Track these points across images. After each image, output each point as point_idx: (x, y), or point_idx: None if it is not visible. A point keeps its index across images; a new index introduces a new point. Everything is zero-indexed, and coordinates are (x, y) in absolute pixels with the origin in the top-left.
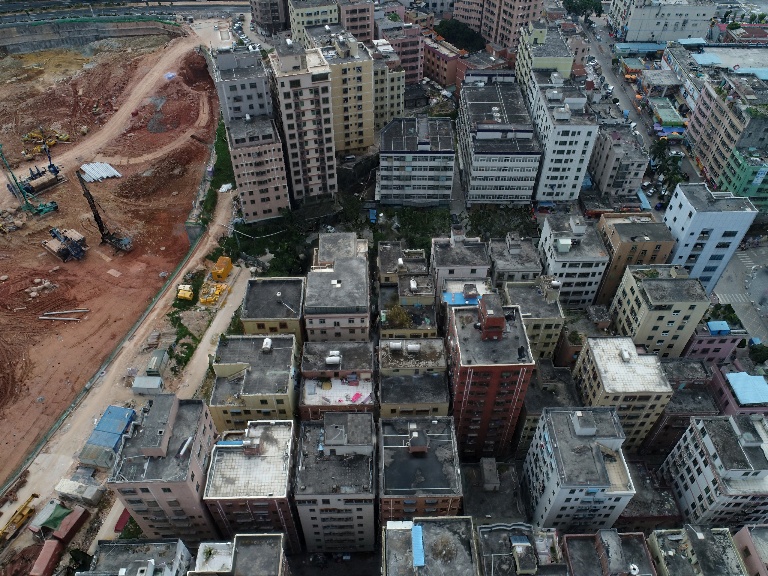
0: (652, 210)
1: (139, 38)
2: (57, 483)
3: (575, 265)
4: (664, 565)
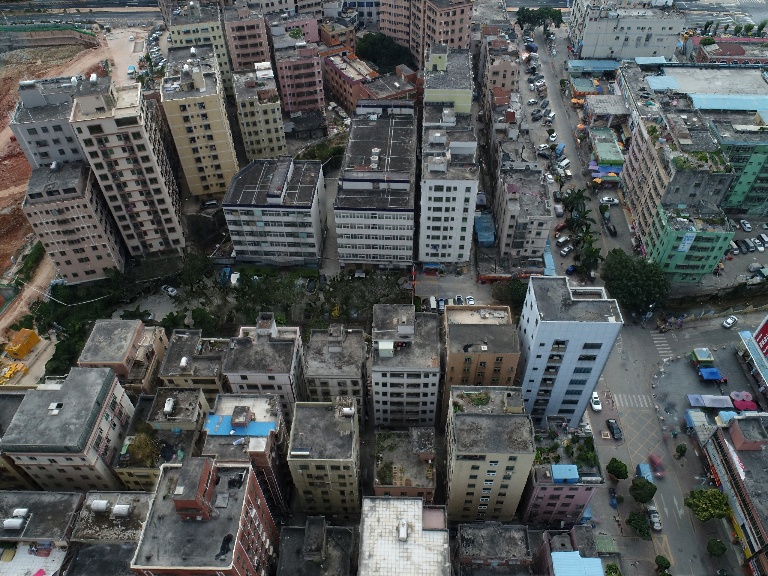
0: (562, 274)
1: (52, 49)
2: None
3: (399, 375)
4: None
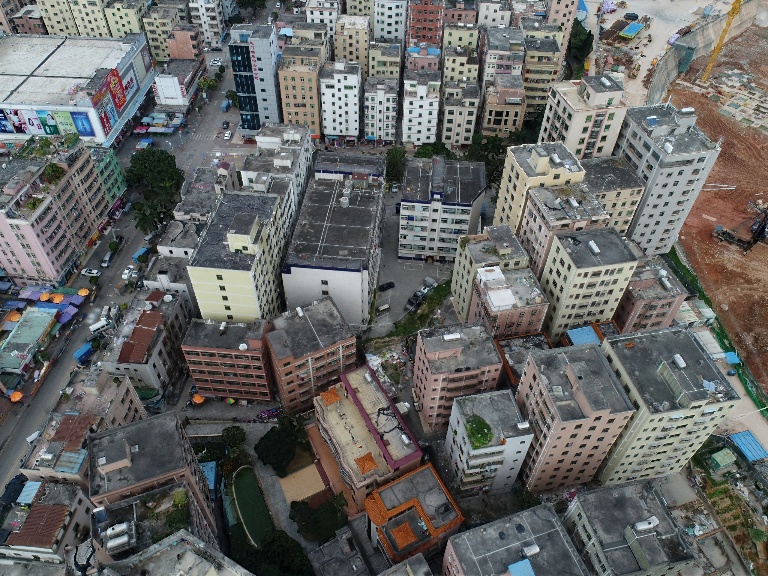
0: None
1: None
2: (628, 85)
3: None
4: None
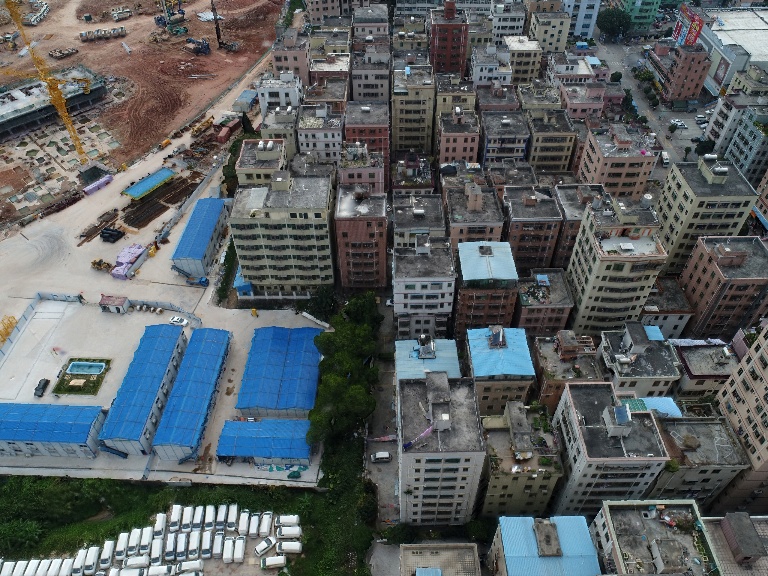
0: None
1: None
2: None
3: (506, 20)
4: (520, 92)
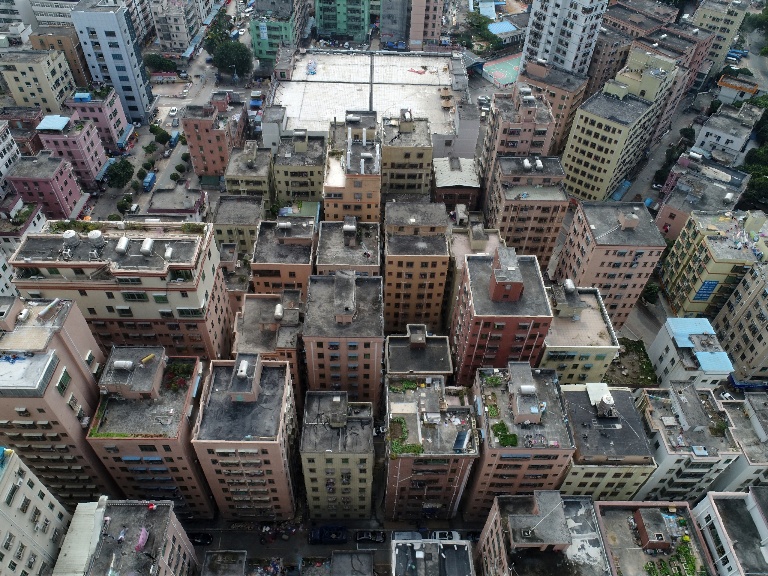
0: (203, 63)
1: None
2: None
3: None
4: None
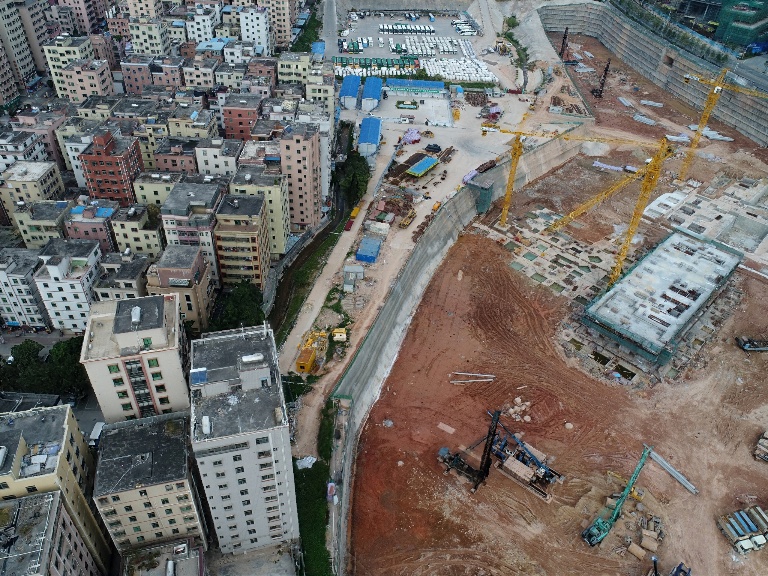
0: None
1: None
2: (394, 237)
3: None
4: None
